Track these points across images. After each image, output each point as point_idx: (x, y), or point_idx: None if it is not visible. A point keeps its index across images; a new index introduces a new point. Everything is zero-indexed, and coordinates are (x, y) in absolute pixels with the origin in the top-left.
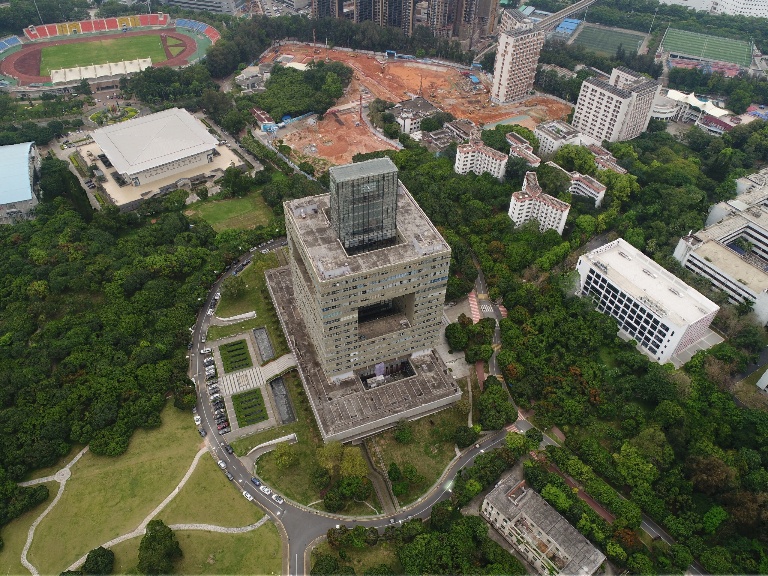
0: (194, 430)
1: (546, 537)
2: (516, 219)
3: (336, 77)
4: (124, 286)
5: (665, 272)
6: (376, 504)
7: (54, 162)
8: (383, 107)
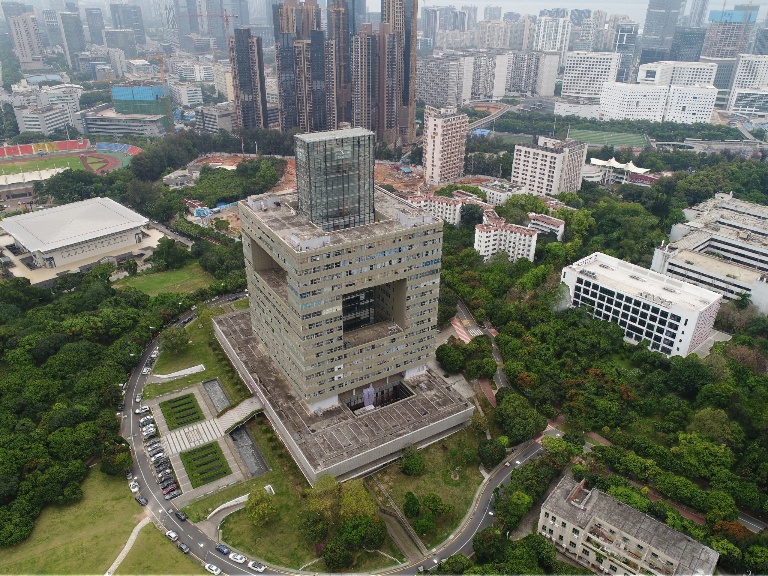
0: (130, 499)
1: (635, 542)
2: (483, 253)
3: (270, 165)
4: (33, 352)
5: (654, 274)
6: (394, 552)
7: None
8: None
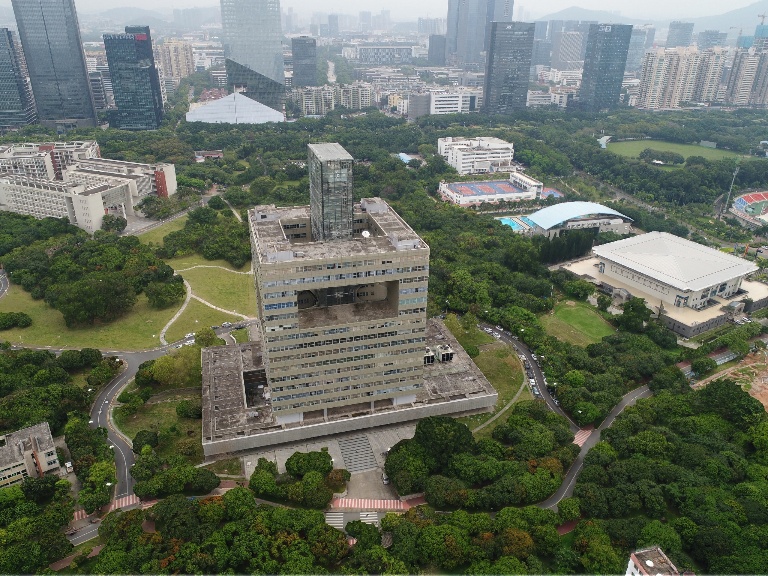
0: None
1: None
2: None
3: None
4: None
5: None
6: None
7: (613, 234)
8: None
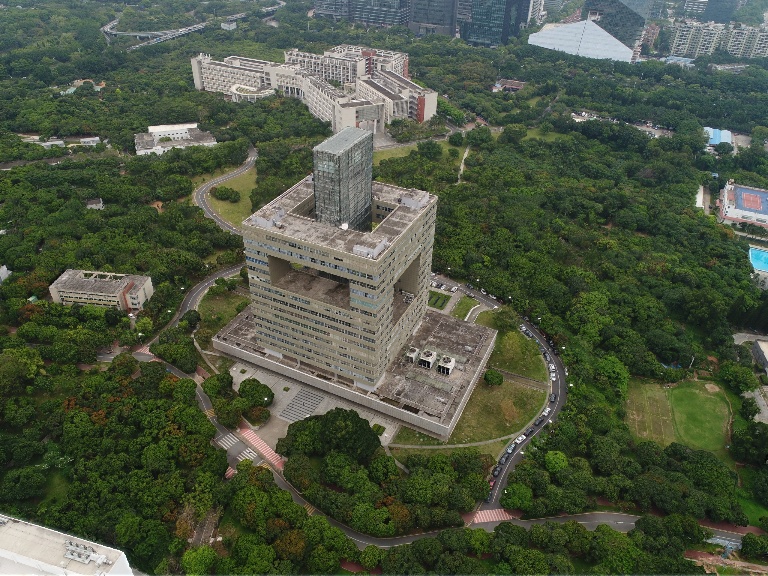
0: None
1: None
2: None
3: None
4: None
5: None
6: None
7: None
8: None
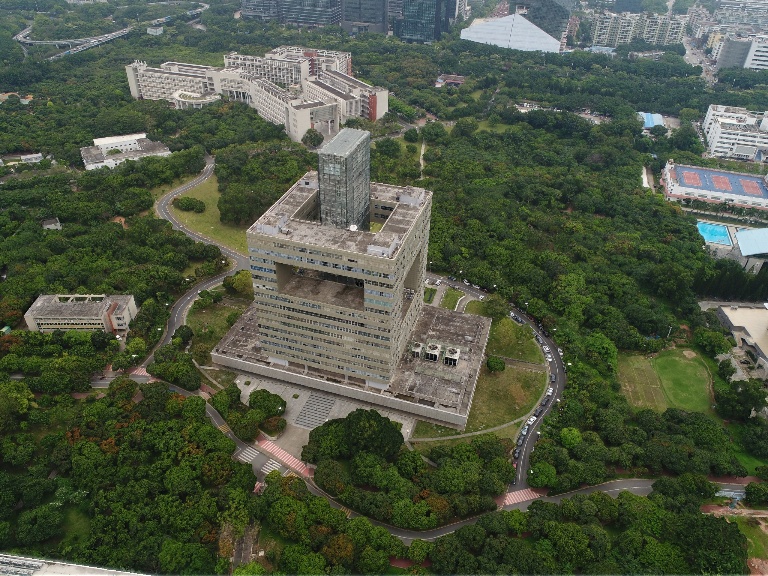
0: None
1: None
2: None
3: None
4: None
5: None
6: None
7: None
8: None
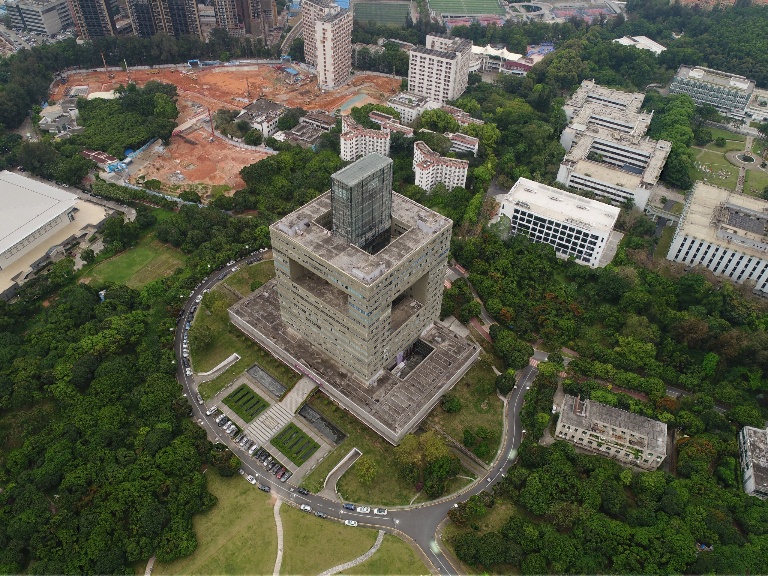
0: (254, 490)
1: (620, 430)
2: (425, 187)
3: (165, 97)
4: (73, 381)
5: (568, 194)
6: (467, 473)
7: None
8: (228, 117)
